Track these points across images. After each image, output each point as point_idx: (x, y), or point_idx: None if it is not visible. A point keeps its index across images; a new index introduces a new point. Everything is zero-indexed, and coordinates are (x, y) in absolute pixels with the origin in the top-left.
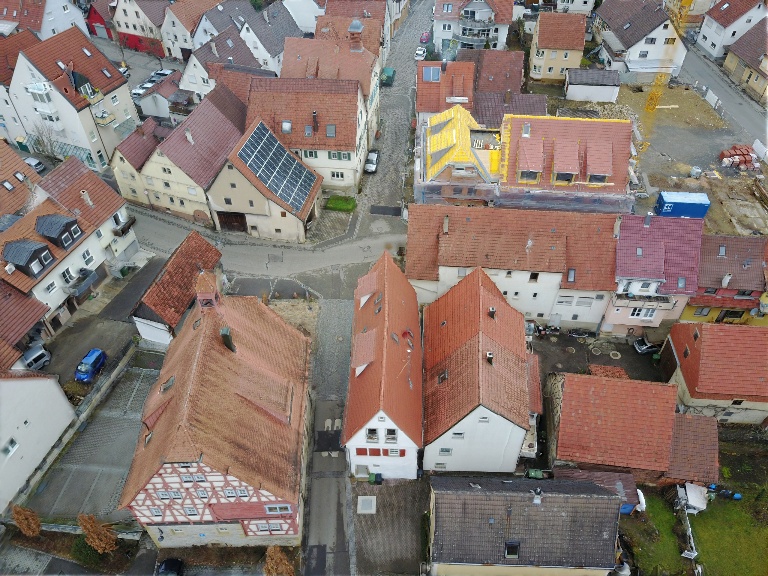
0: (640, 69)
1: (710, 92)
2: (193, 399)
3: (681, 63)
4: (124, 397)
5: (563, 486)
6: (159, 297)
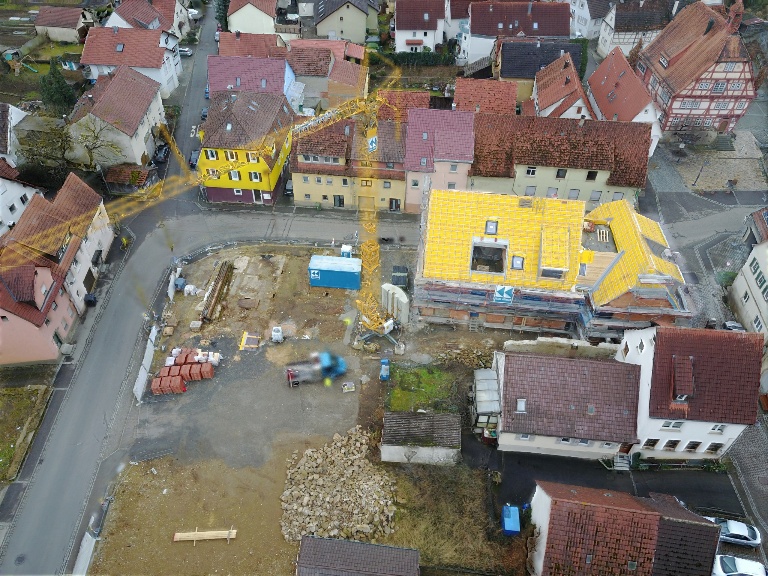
0: None
1: (78, 567)
2: (703, 7)
3: None
4: None
5: (518, 69)
6: None
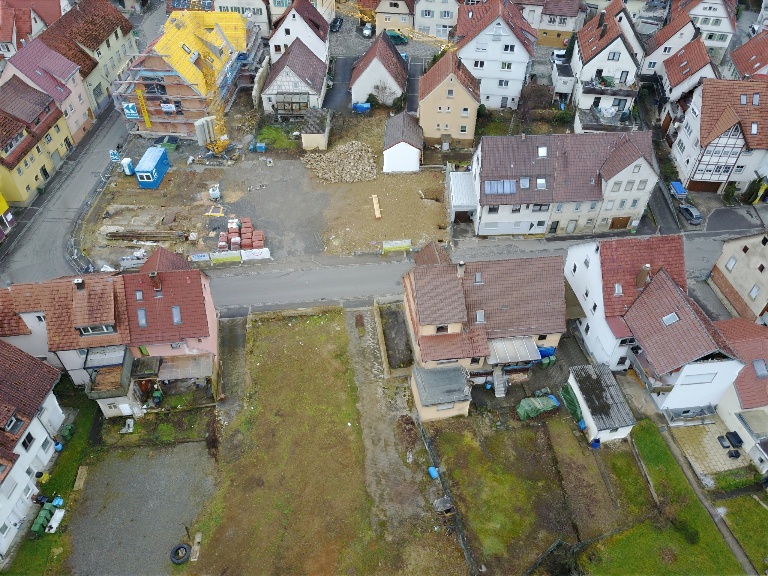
0: None
1: (405, 240)
2: None
3: None
4: (70, 0)
5: None
6: None
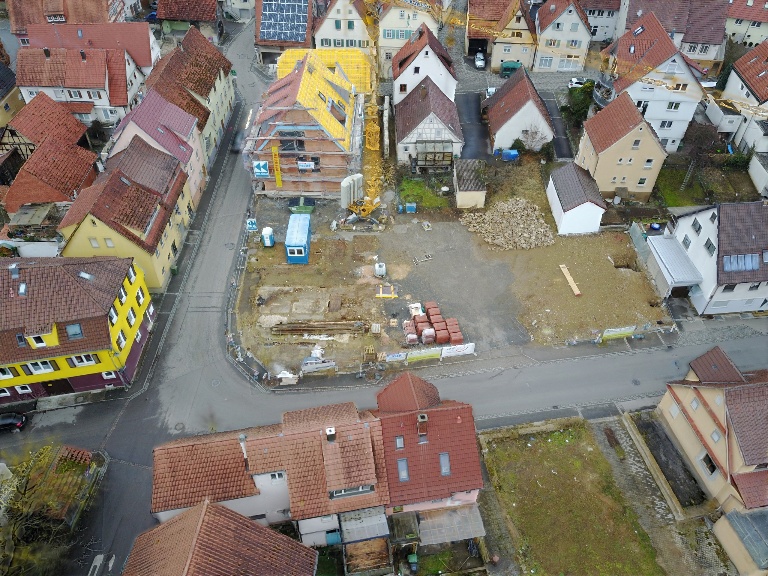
0: (653, 247)
1: (629, 327)
2: None
3: (708, 296)
4: None
5: None
6: (165, 1)
